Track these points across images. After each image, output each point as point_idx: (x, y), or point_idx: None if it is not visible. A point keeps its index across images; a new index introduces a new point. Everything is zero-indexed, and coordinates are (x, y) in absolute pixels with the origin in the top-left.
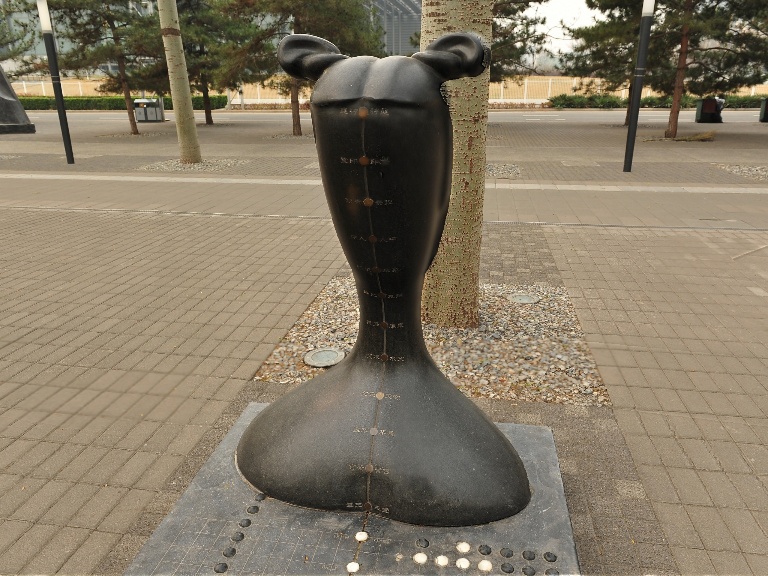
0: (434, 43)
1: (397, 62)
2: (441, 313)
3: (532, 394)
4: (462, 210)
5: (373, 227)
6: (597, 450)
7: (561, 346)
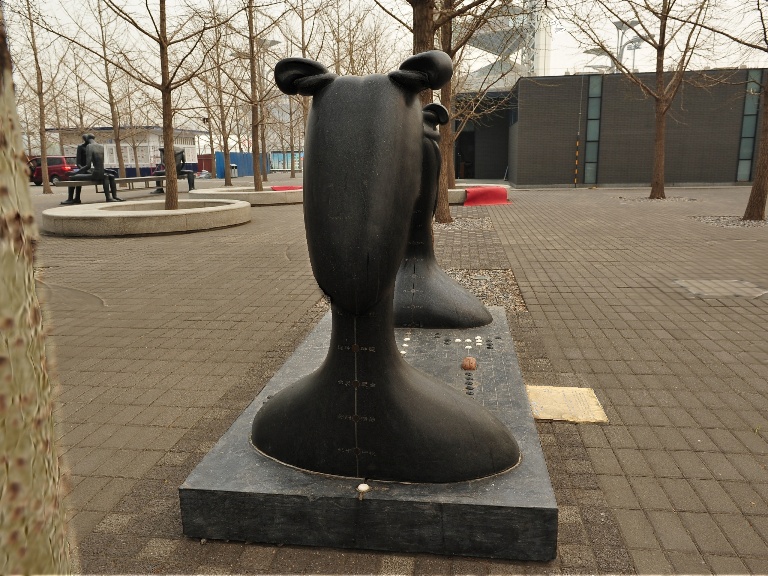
0: None
1: None
2: None
3: None
4: None
5: None
6: (94, 569)
7: None
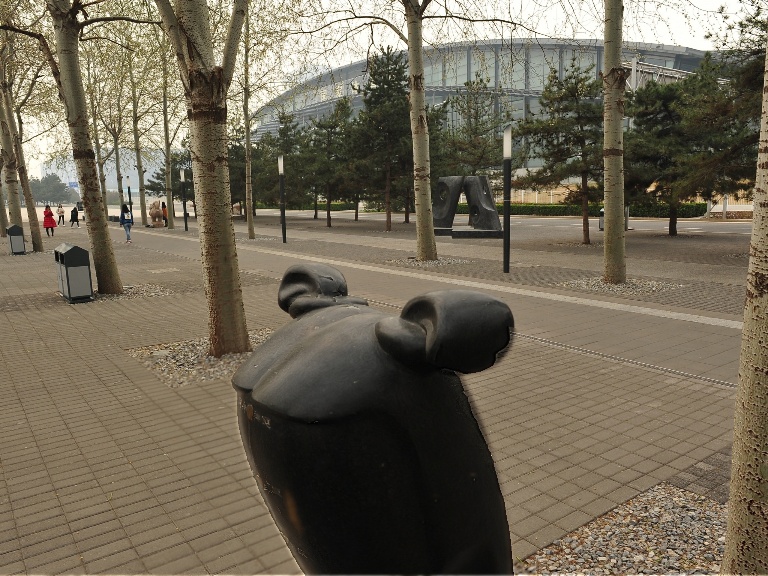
0: (410, 306)
1: (344, 332)
2: None
3: None
4: None
5: None
6: None
7: None
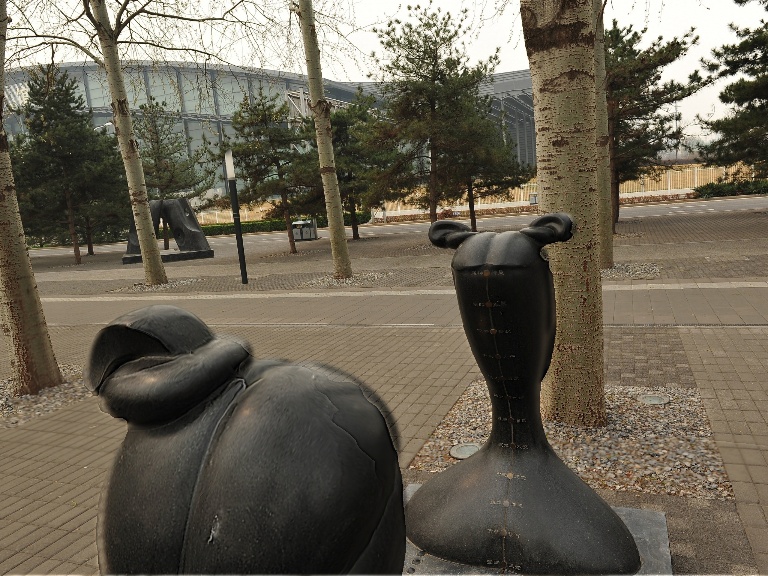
0: (535, 221)
1: (509, 237)
2: (570, 413)
3: (657, 487)
4: (582, 322)
5: (498, 348)
6: (716, 538)
7: (688, 444)
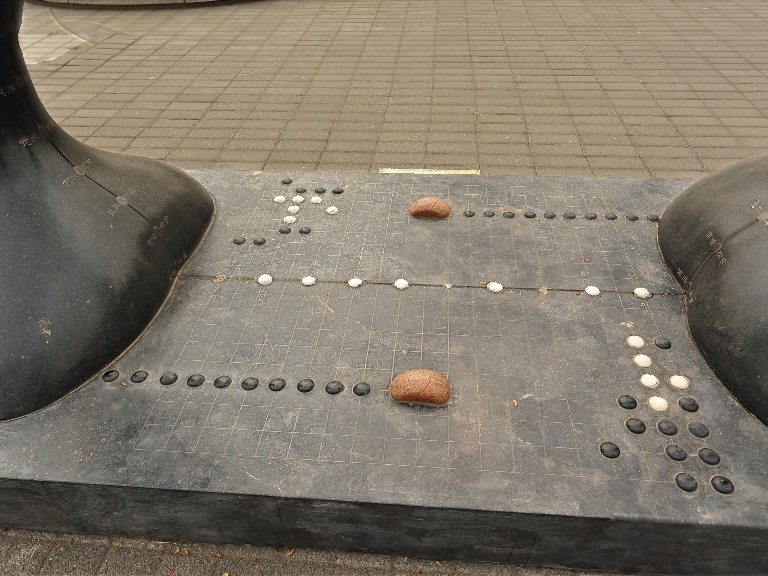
0: None
1: None
2: None
3: None
4: None
5: None
6: None
7: None
